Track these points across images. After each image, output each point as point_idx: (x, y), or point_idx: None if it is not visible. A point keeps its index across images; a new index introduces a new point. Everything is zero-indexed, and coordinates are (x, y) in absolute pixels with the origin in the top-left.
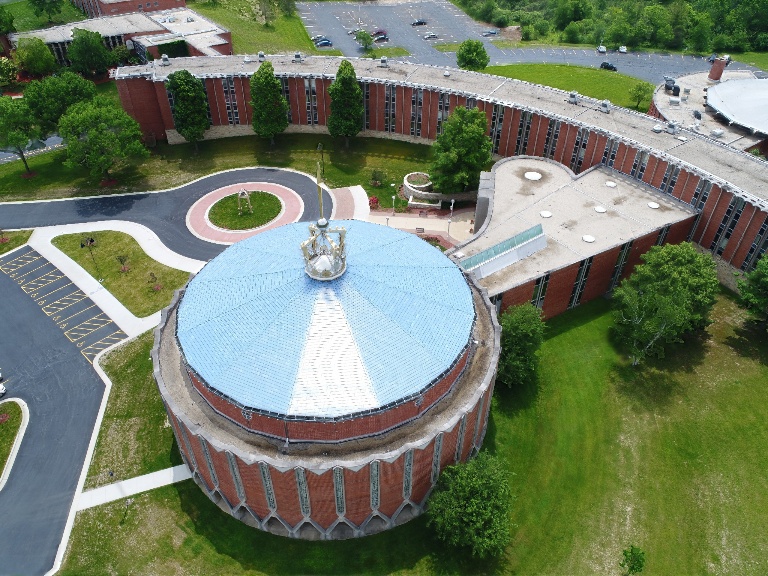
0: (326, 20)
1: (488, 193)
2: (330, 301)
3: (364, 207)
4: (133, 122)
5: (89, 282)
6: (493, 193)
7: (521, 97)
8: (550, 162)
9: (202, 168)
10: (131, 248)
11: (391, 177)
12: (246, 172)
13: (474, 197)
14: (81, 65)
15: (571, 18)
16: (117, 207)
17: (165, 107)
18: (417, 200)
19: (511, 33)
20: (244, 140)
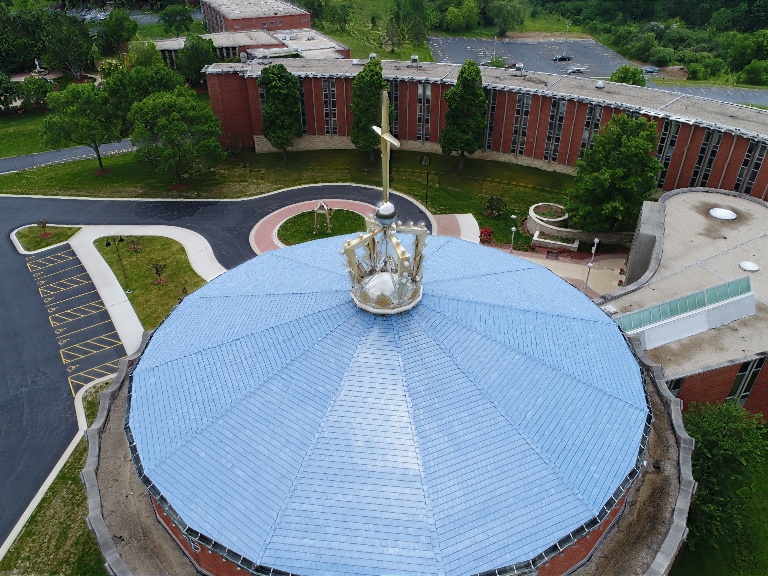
0: (457, 52)
1: (655, 229)
2: (383, 350)
3: (472, 239)
4: (213, 118)
5: (115, 292)
6: (663, 230)
7: (705, 114)
8: (748, 199)
9: (286, 180)
10: (177, 258)
11: (512, 208)
12: (335, 188)
13: (626, 240)
14: (188, 71)
15: (751, 59)
16: (179, 212)
17: (256, 109)
18: (545, 237)
19: (672, 73)
20: (340, 154)
